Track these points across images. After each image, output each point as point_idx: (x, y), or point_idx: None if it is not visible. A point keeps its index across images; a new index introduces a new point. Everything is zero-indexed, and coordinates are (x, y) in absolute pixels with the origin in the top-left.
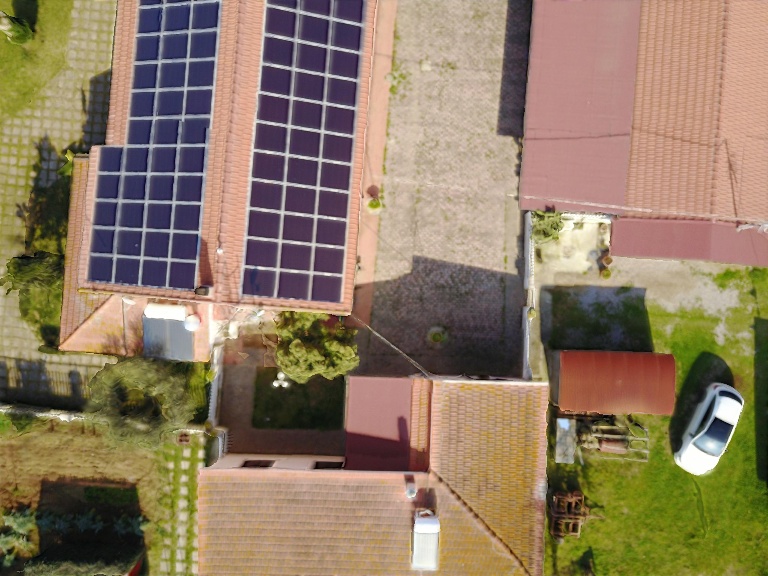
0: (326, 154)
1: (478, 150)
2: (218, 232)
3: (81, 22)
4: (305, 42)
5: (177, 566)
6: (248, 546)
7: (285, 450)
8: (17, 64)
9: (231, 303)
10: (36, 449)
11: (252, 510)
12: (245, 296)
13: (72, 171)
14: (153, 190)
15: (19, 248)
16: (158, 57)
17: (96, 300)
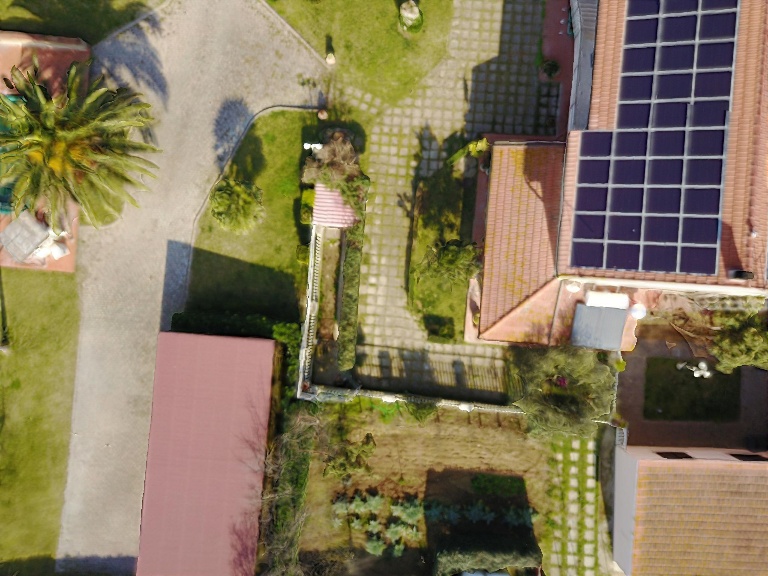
0: None
1: None
2: (747, 216)
3: (463, 12)
4: None
5: (568, 559)
6: (686, 539)
7: (679, 443)
8: (398, 54)
9: (758, 288)
10: (421, 439)
11: (692, 502)
12: (767, 281)
13: (491, 159)
14: (654, 174)
15: (400, 238)
16: (656, 40)
17: (527, 288)
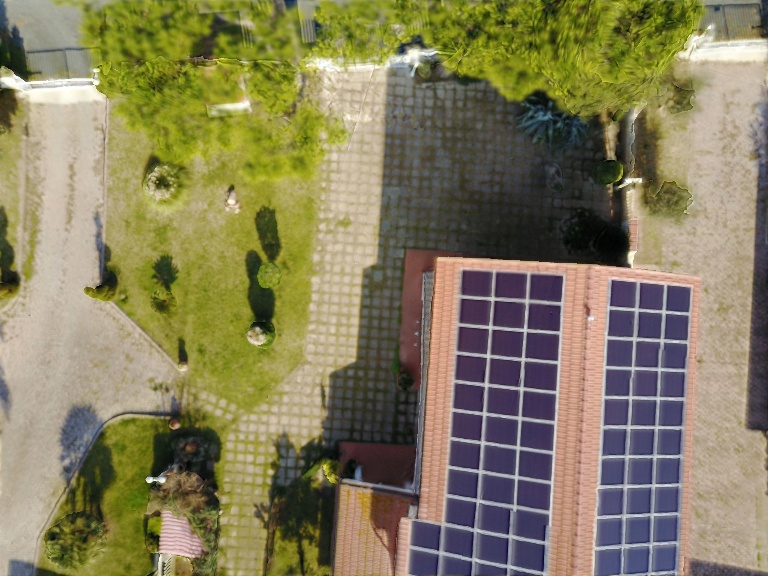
0: (656, 537)
1: (726, 444)
2: None
3: (320, 315)
4: (637, 427)
5: None
6: None
7: None
8: (254, 359)
9: None
10: None
11: None
12: None
13: (339, 498)
14: None
15: (257, 550)
16: (481, 437)
17: None
